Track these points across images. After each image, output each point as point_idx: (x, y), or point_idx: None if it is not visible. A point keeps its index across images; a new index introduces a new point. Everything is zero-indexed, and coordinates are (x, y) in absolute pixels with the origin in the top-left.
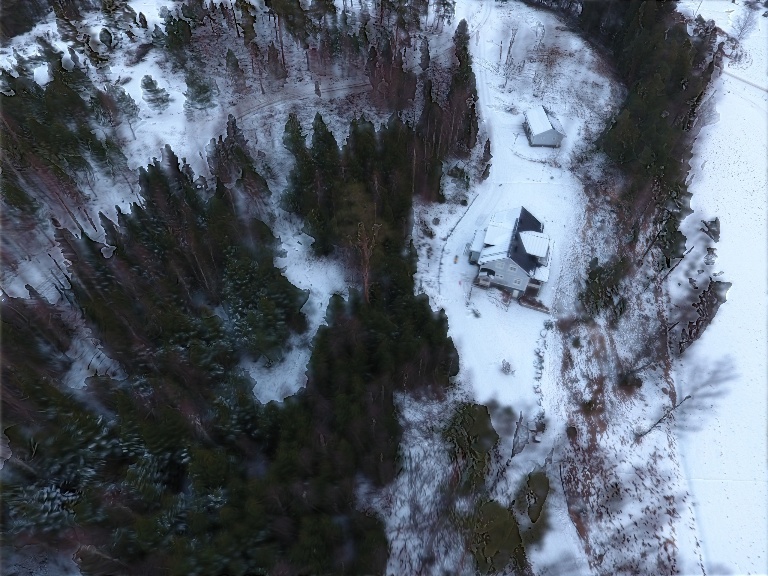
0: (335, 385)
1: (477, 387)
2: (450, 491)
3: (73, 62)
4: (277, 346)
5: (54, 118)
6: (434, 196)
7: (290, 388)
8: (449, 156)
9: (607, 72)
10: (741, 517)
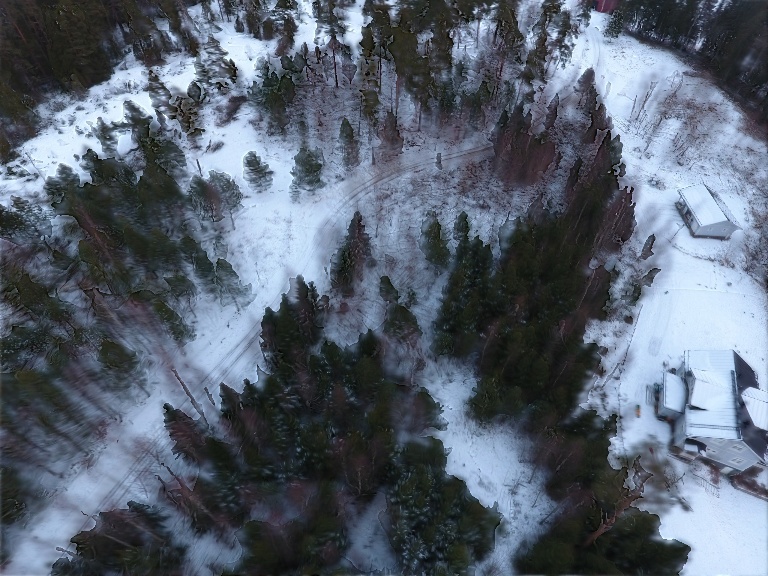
0: None
1: None
2: None
3: (158, 122)
4: None
5: (148, 215)
6: (595, 313)
7: None
8: (597, 249)
9: (758, 133)
10: None
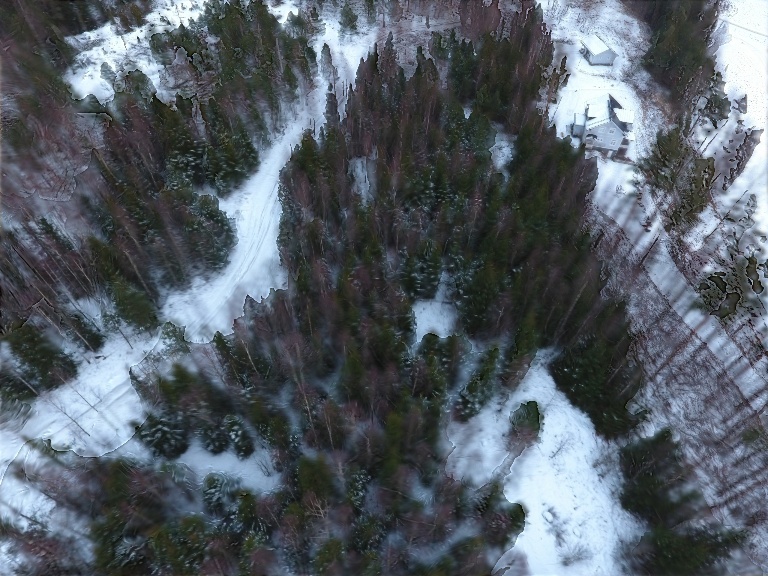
0: None
1: (602, 204)
2: (607, 249)
3: None
4: (491, 161)
5: None
6: None
7: None
8: None
9: (632, 14)
10: None
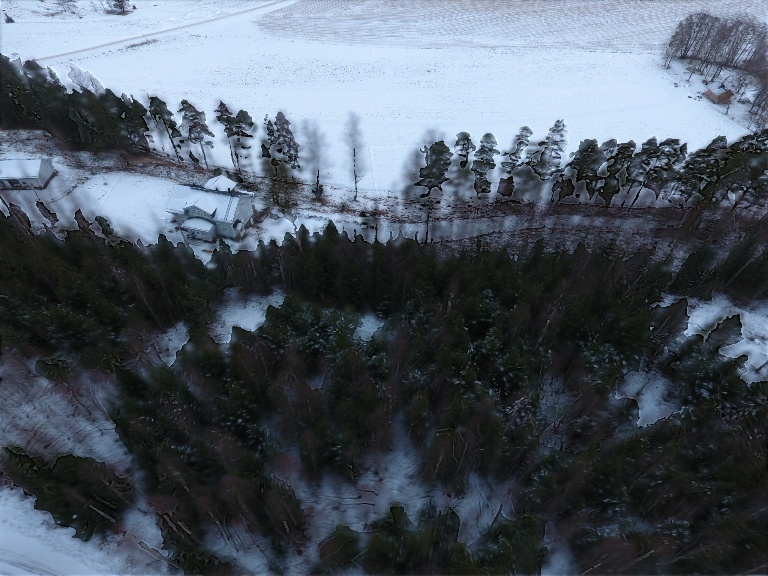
0: (390, 260)
1: None
2: None
3: None
4: None
5: None
6: None
7: (370, 327)
8: None
9: None
10: (393, 178)
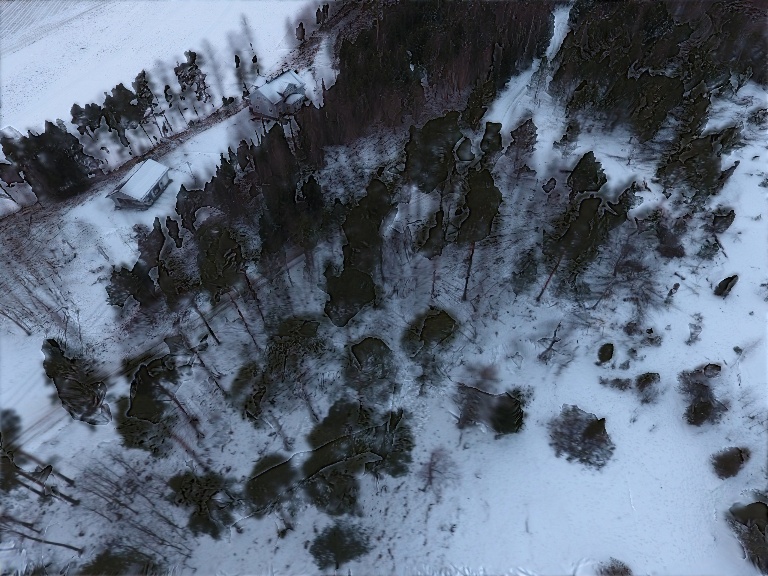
0: None
1: None
2: None
3: (731, 200)
4: None
5: None
6: None
7: None
8: None
9: None
10: None
